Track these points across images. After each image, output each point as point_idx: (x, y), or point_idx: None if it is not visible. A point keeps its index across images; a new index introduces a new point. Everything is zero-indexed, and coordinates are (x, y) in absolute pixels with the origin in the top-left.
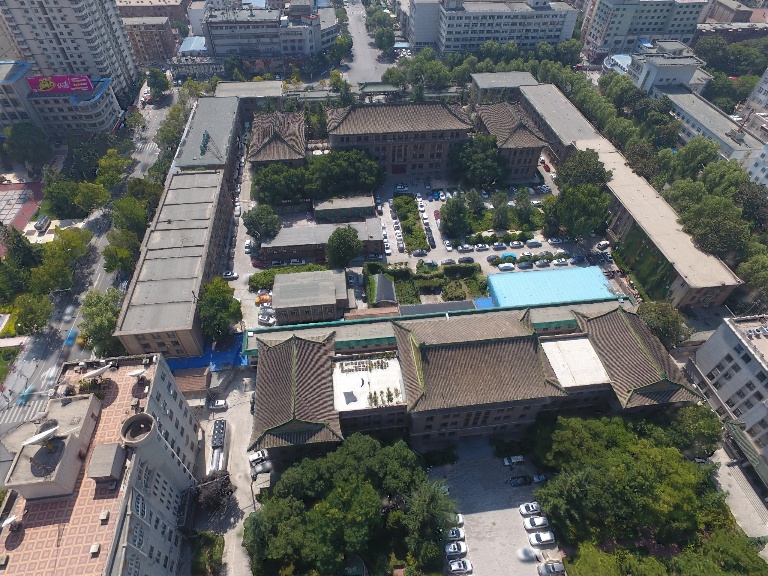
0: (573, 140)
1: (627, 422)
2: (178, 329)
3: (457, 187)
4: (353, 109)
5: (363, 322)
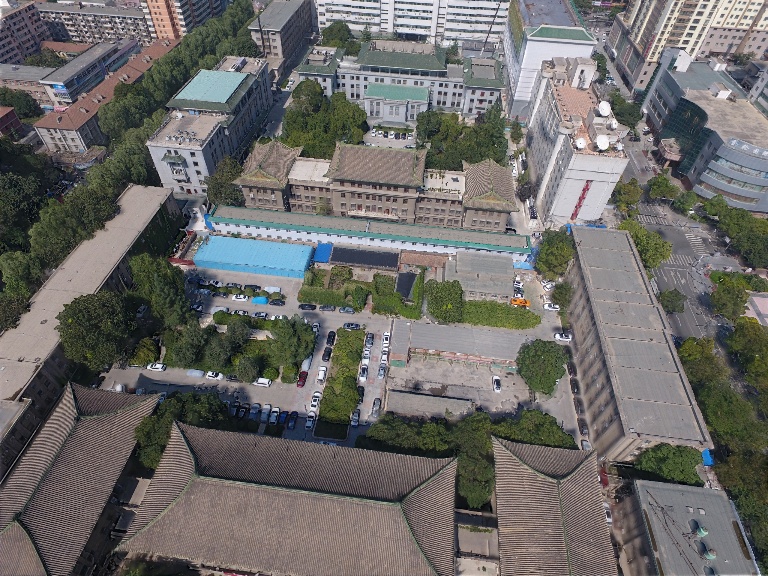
0: (1, 411)
1: (303, 150)
2: (581, 226)
3: (242, 425)
4: (398, 499)
5: (435, 239)
